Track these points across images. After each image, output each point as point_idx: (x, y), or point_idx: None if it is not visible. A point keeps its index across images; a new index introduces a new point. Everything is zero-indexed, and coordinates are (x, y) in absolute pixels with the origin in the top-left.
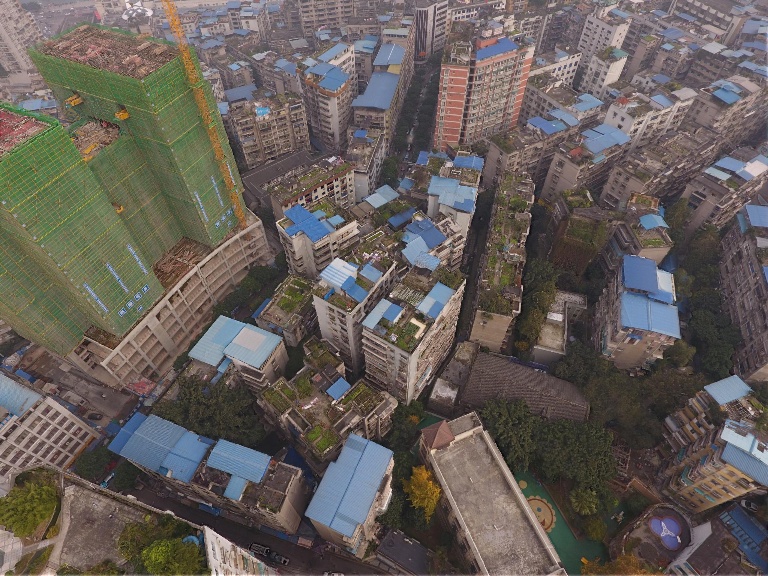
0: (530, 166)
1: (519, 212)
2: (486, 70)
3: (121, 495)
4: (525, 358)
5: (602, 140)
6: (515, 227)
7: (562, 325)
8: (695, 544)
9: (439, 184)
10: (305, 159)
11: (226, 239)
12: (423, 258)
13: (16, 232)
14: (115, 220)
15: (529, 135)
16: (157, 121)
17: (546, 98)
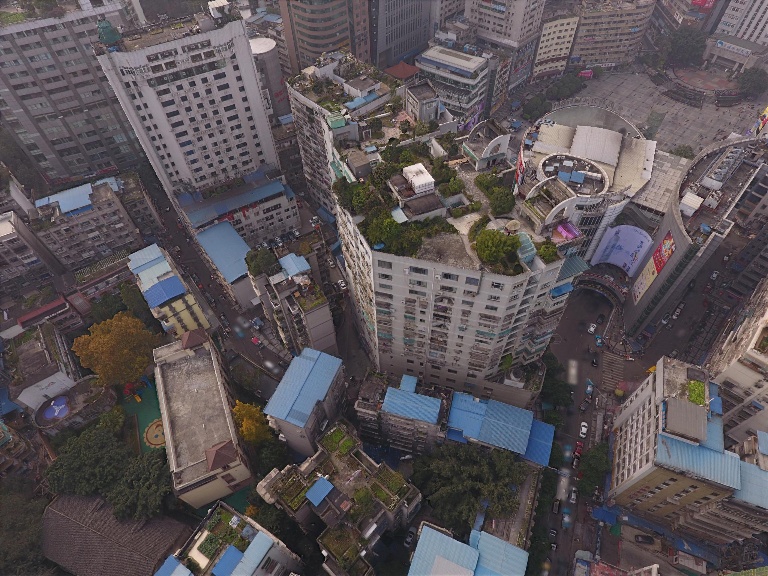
0: None
1: None
2: None
3: (437, 263)
4: None
5: None
6: None
7: None
8: (43, 391)
9: None
10: None
11: None
12: None
13: None
14: None
15: None
16: None
17: None
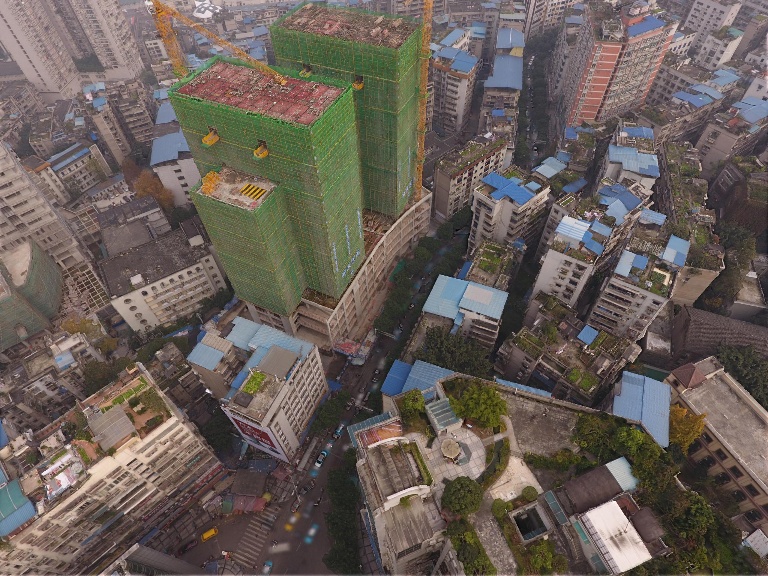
0: (675, 139)
1: (695, 178)
2: (635, 47)
3: None
4: (723, 313)
5: (755, 111)
6: (694, 192)
7: (755, 282)
8: None
9: (618, 152)
10: (434, 140)
11: (404, 210)
12: (648, 214)
13: (300, 190)
14: (357, 183)
15: (675, 109)
16: (396, 90)
17: (678, 75)
